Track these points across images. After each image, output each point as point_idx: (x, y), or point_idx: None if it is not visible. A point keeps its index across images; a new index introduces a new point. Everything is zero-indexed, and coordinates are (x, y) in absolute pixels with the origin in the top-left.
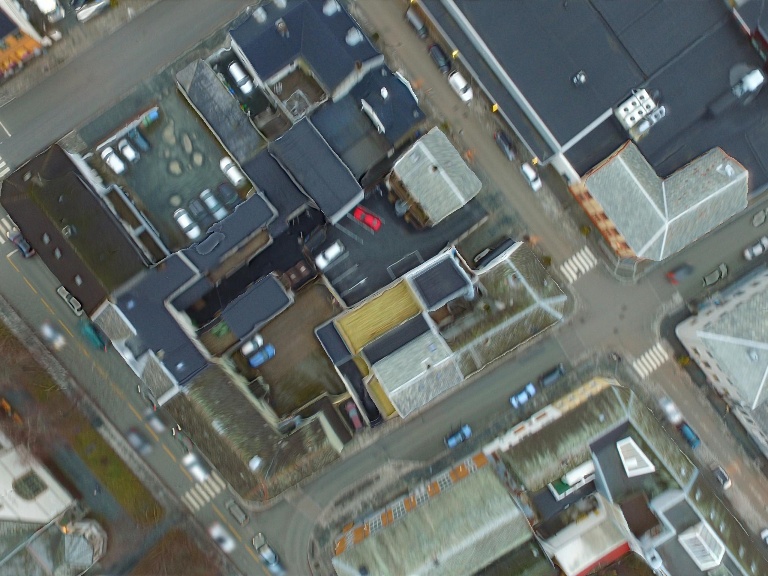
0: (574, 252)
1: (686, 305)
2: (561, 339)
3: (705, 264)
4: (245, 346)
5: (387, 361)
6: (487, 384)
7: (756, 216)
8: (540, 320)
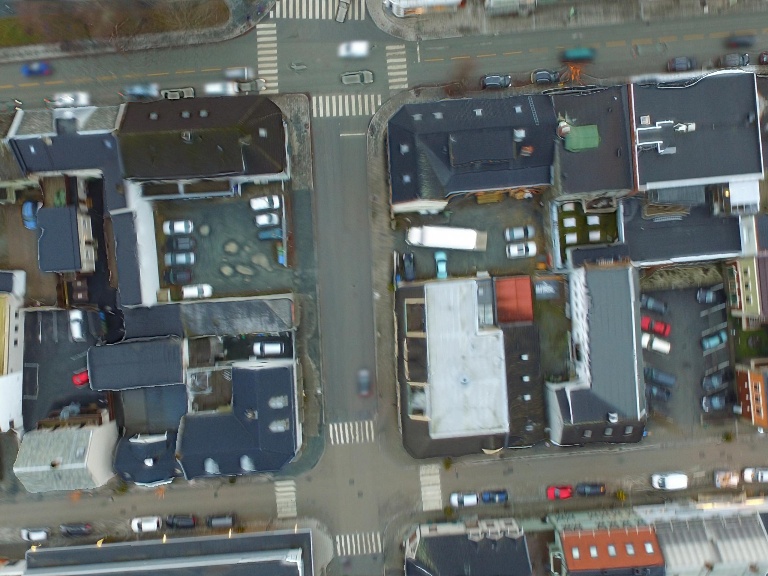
0: None
1: None
2: None
3: None
4: None
5: None
6: None
7: None
8: None
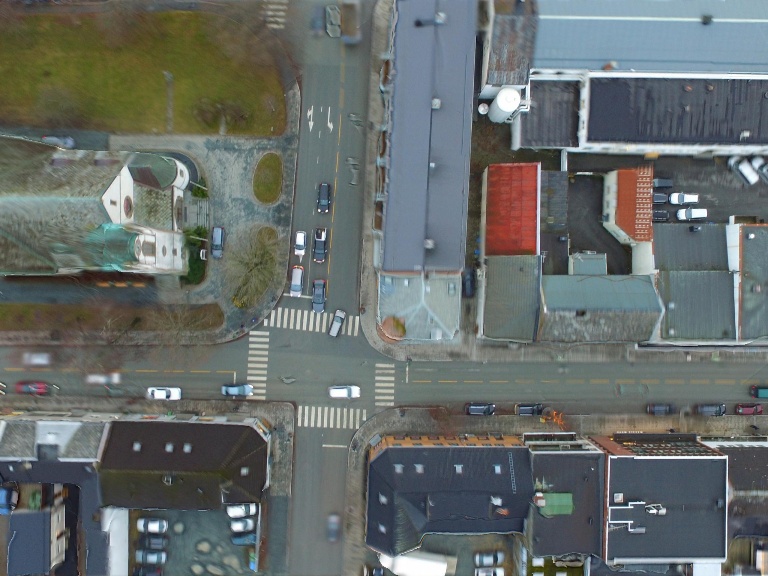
0: None
1: None
2: None
3: None
4: None
5: None
6: None
7: None
8: None
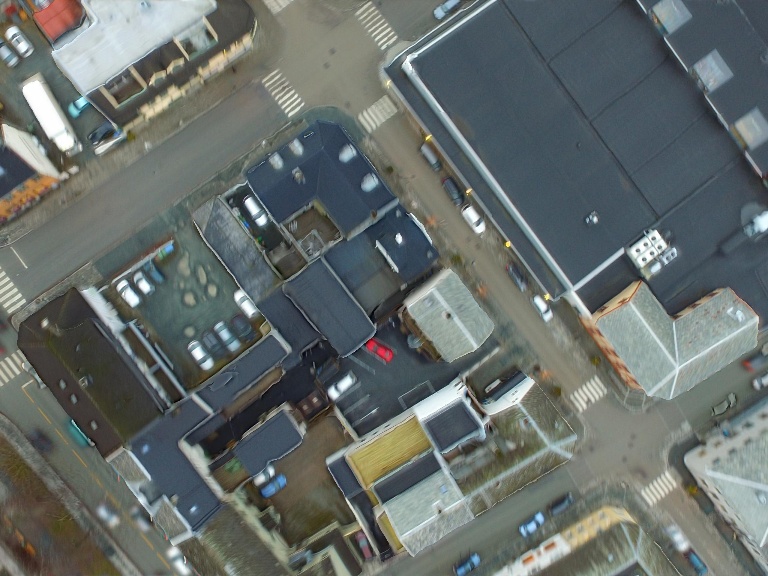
0: (584, 382)
1: (695, 434)
2: (570, 467)
3: (714, 393)
4: (257, 477)
5: (398, 500)
6: (496, 512)
7: (765, 345)
8: (550, 461)
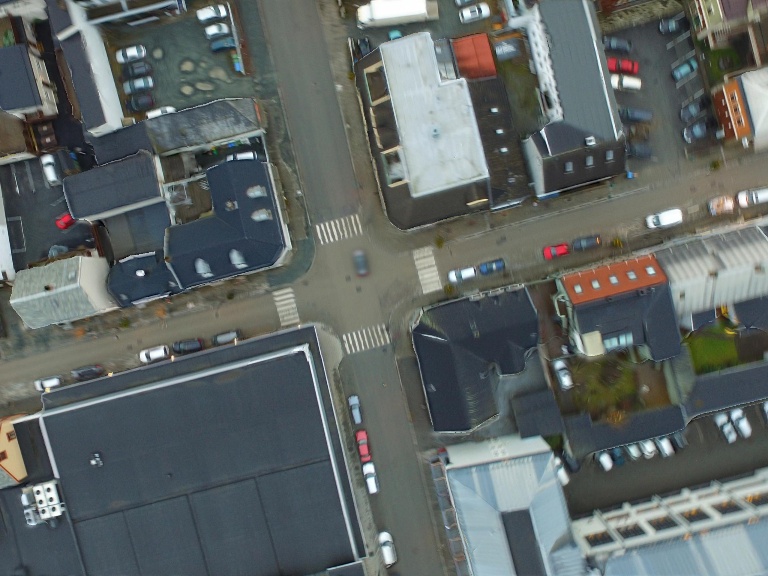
0: None
1: None
2: None
3: None
4: None
5: None
6: None
7: None
8: None
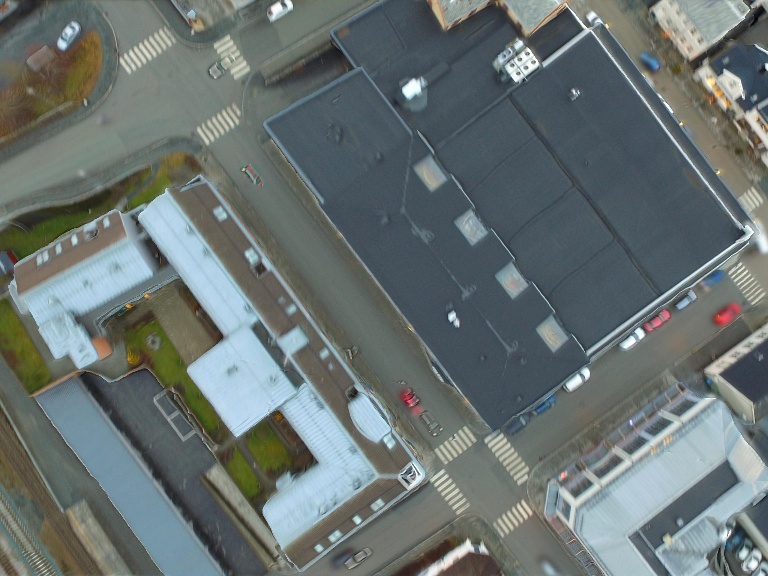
0: None
1: None
2: None
3: None
4: None
5: None
6: None
7: None
8: None
